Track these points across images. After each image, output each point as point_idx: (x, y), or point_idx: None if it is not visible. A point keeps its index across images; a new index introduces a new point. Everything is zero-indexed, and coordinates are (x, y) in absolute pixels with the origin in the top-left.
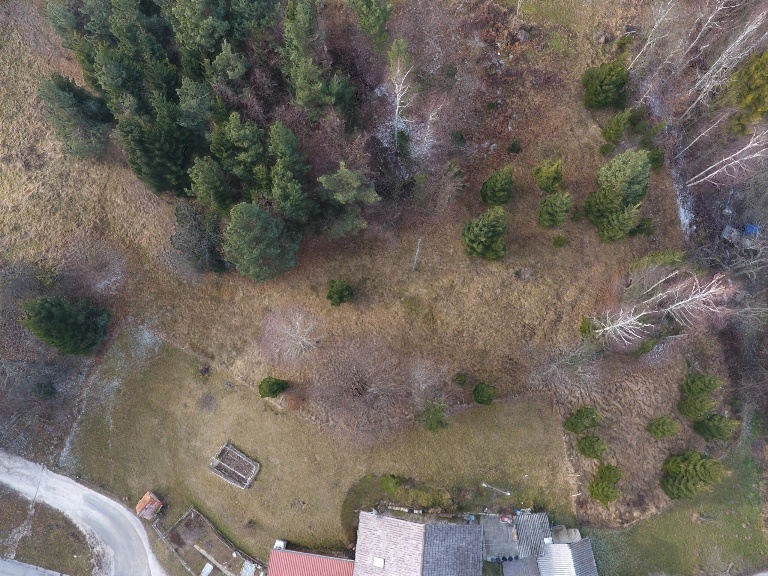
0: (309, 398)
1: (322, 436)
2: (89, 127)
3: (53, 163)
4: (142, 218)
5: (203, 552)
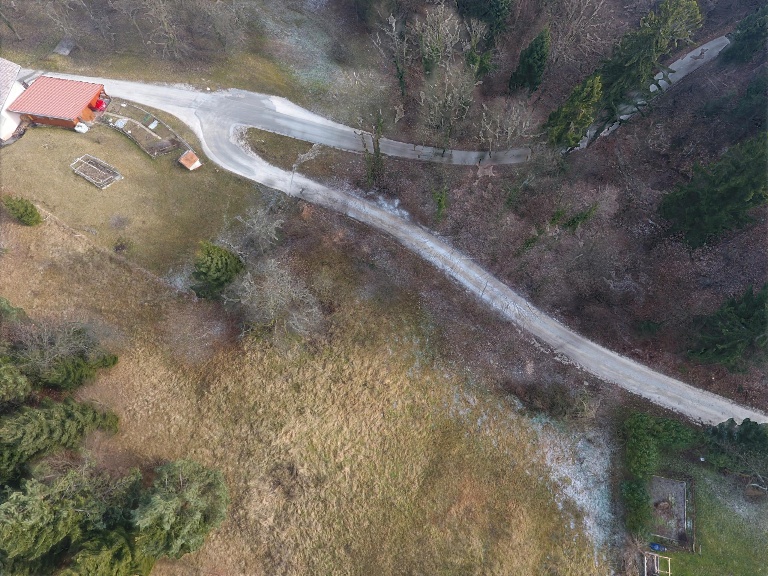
0: (5, 210)
1: (2, 182)
2: (166, 497)
3: (261, 473)
4: (155, 396)
5: (155, 135)
